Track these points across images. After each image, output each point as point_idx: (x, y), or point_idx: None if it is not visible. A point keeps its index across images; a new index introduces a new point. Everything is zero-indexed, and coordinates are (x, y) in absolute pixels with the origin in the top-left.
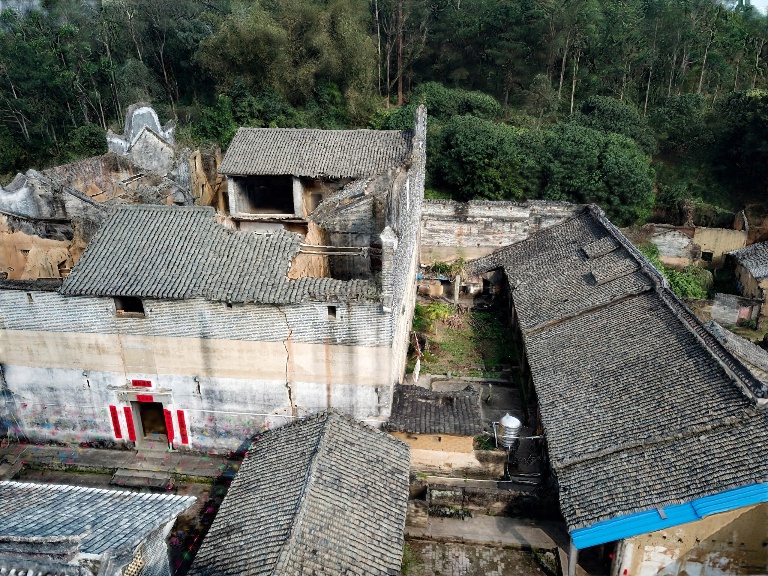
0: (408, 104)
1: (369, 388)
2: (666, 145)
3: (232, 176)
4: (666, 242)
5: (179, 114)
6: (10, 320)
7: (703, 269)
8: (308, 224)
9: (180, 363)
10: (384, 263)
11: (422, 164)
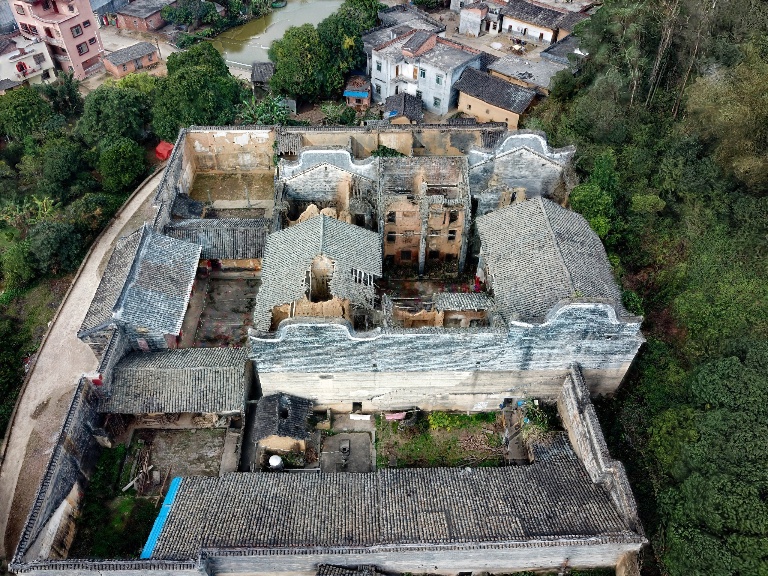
0: None
1: None
2: None
3: None
4: None
5: None
6: None
7: None
8: (333, 297)
9: None
10: None
11: (572, 339)
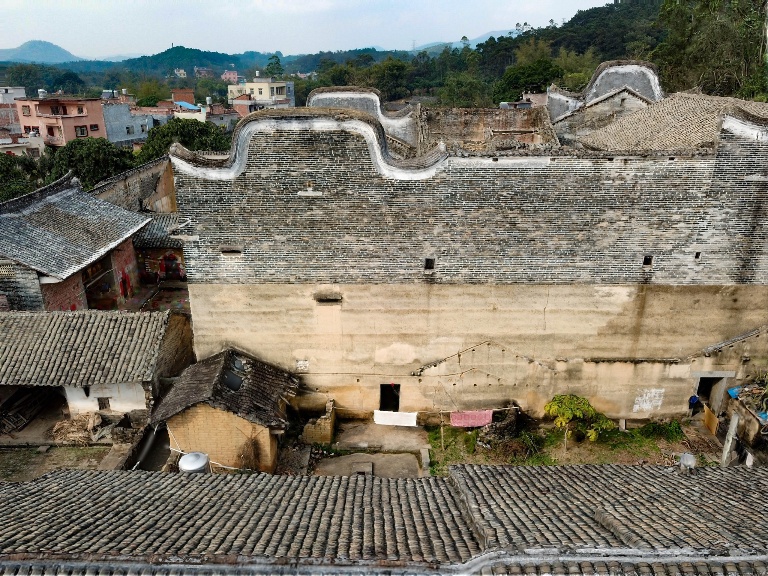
0: None
1: None
2: None
3: None
4: None
5: None
6: None
7: None
8: None
9: None
10: None
11: None
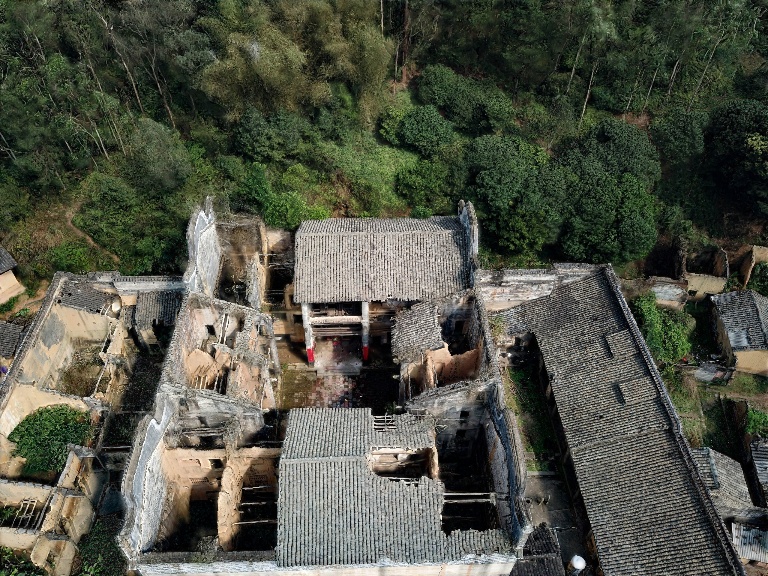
0: (413, 84)
1: (495, 575)
2: (667, 161)
3: (307, 302)
4: (663, 291)
5: (178, 123)
6: (233, 570)
7: (690, 318)
8: (433, 448)
9: (362, 575)
10: (521, 539)
11: None
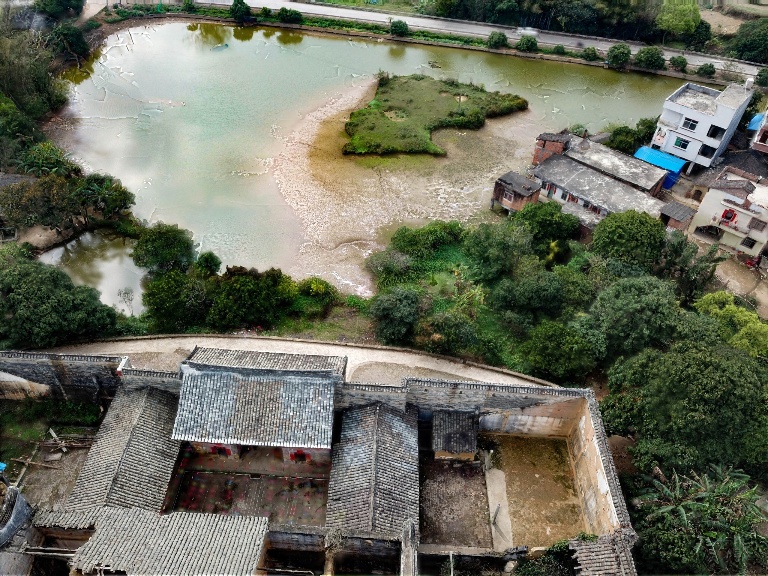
0: None
1: None
2: None
3: None
4: None
5: None
6: None
7: None
8: None
9: None
10: None
11: None
